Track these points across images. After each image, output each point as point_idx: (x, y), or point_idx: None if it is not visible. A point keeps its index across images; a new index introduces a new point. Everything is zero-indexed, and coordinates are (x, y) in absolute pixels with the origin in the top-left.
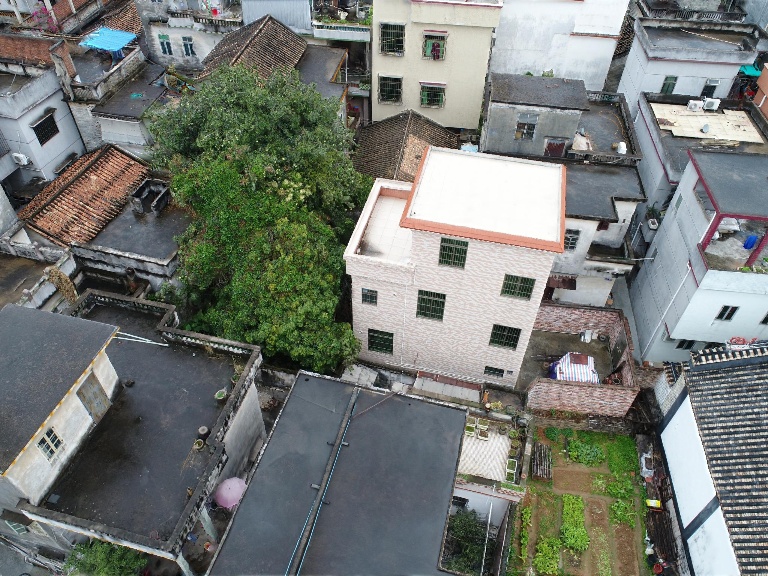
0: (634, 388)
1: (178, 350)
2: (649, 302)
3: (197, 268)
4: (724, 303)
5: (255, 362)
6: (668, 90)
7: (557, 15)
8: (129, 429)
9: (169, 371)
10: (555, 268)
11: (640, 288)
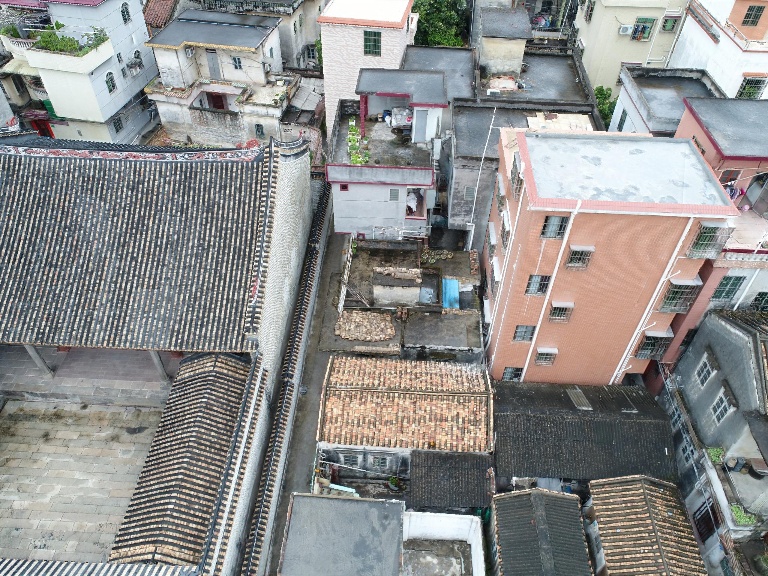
0: (312, 163)
1: None
2: None
3: None
4: None
5: (286, 8)
6: (621, 126)
7: (703, 50)
8: None
9: None
10: None
11: None
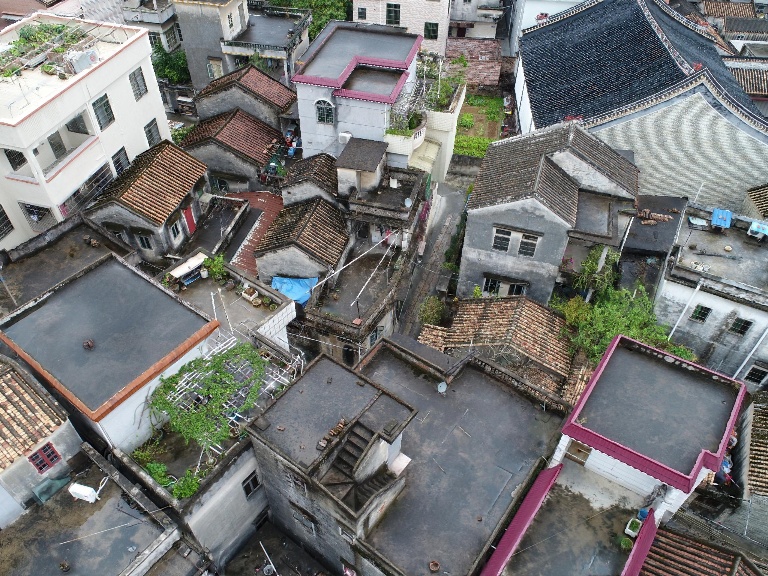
0: (499, 60)
1: (272, 17)
2: (514, 36)
3: (273, 1)
4: (540, 11)
5: (310, 16)
6: None
7: None
8: (257, 34)
9: (270, 22)
10: (462, 17)
11: (512, 35)
